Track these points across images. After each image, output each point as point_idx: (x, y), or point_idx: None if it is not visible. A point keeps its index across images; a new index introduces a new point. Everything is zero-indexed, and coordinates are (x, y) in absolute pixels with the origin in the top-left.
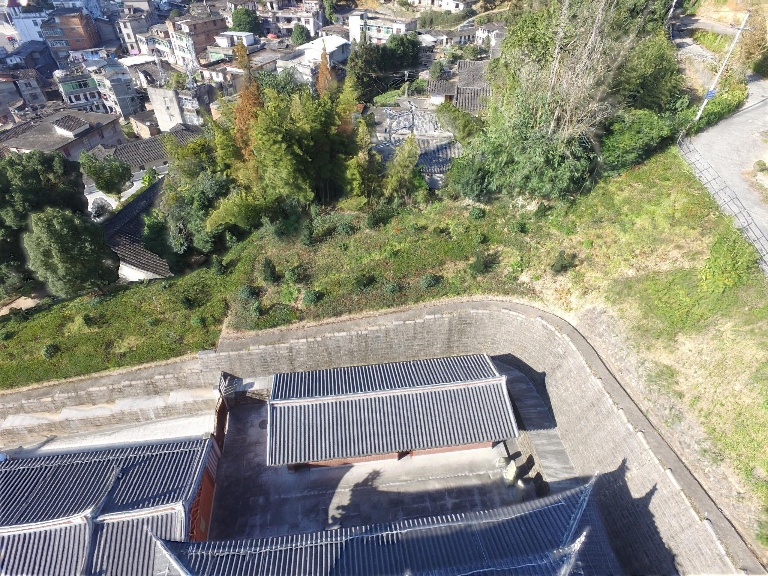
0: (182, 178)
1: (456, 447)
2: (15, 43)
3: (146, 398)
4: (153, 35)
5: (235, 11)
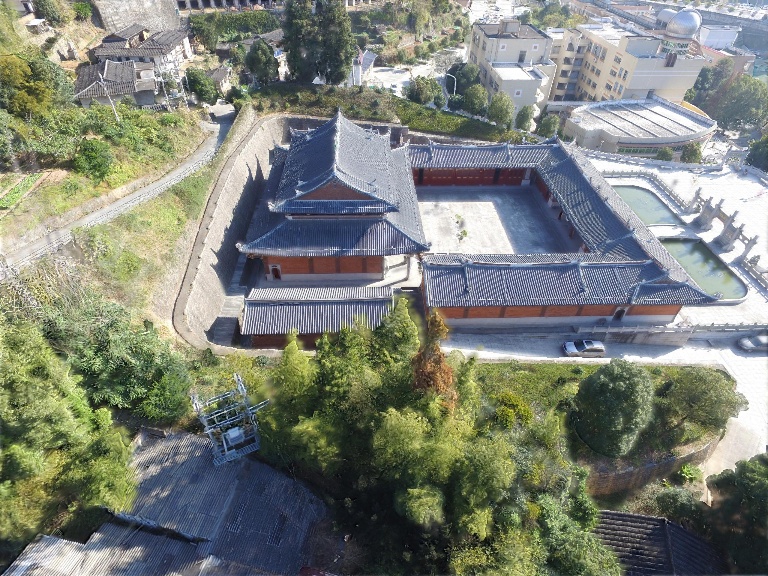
0: None
1: None
2: None
3: None
4: None
5: None
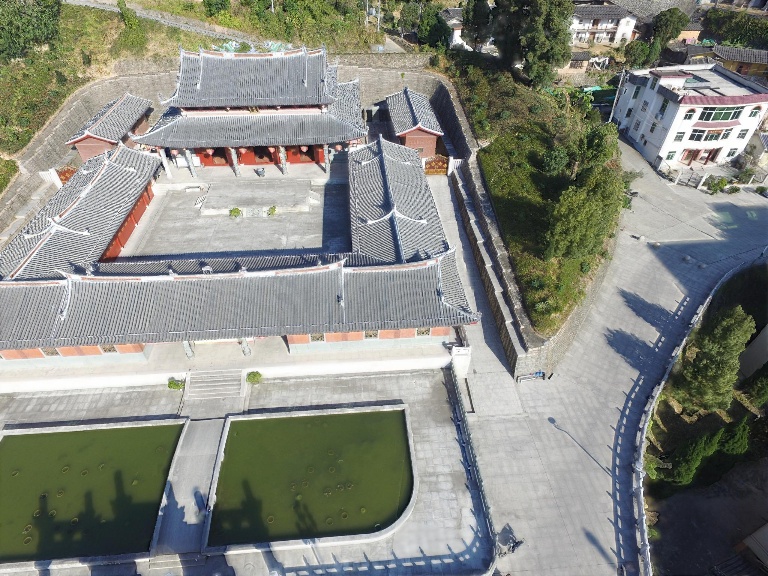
0: None
1: (143, 130)
2: None
3: (25, 206)
4: None
5: None
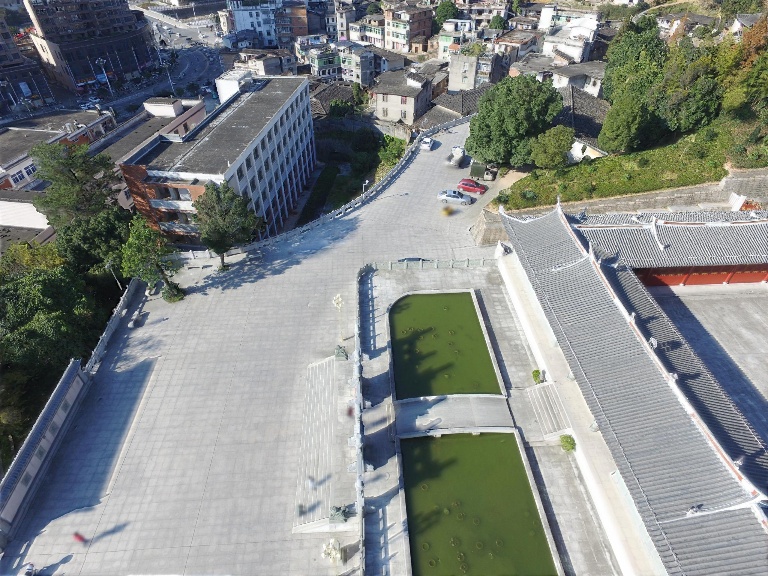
0: (685, 82)
1: None
2: (232, 31)
3: (685, 206)
4: (365, 24)
5: (442, 4)
